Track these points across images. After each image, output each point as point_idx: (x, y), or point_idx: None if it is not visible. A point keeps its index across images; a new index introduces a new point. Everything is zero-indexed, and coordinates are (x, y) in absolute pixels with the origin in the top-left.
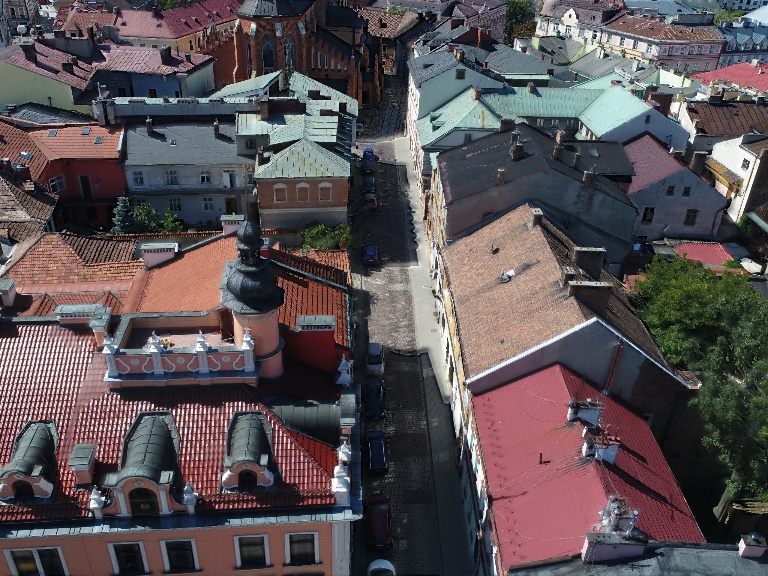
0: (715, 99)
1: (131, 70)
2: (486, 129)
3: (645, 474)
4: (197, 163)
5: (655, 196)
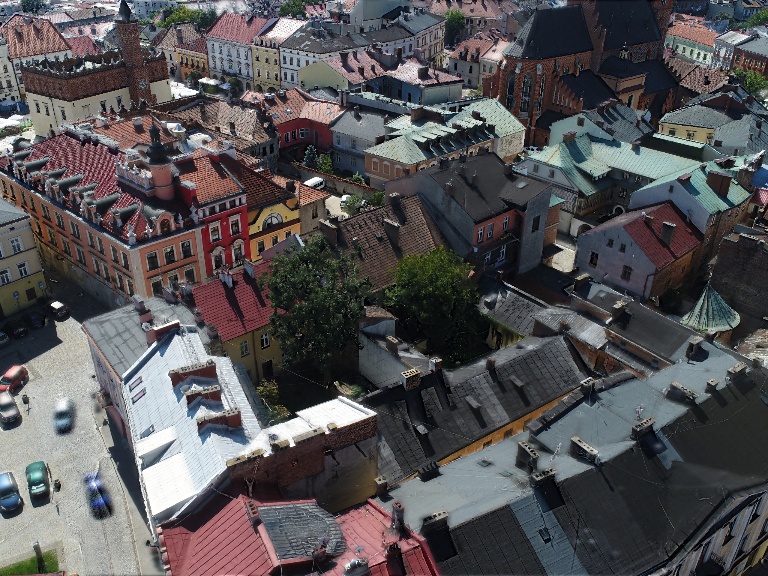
0: None
1: (400, 78)
2: (548, 164)
3: (250, 306)
4: (362, 138)
5: (598, 244)
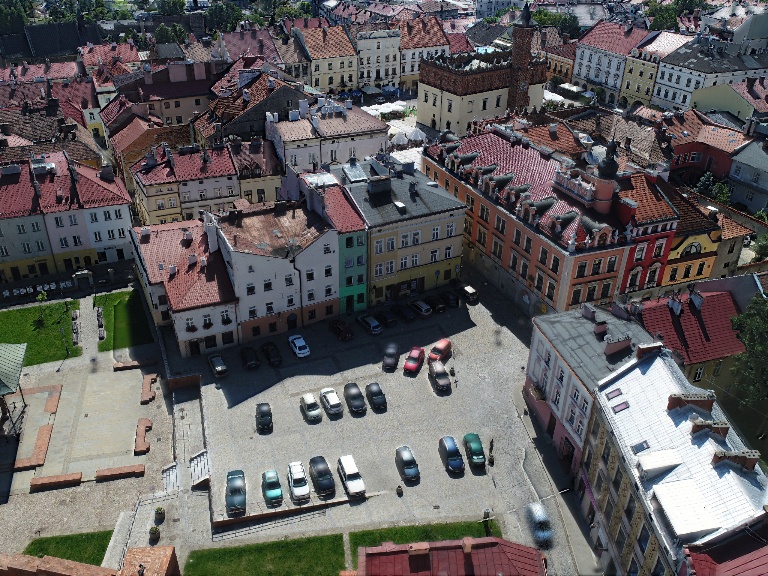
0: None
1: None
2: None
3: (695, 338)
4: None
5: None
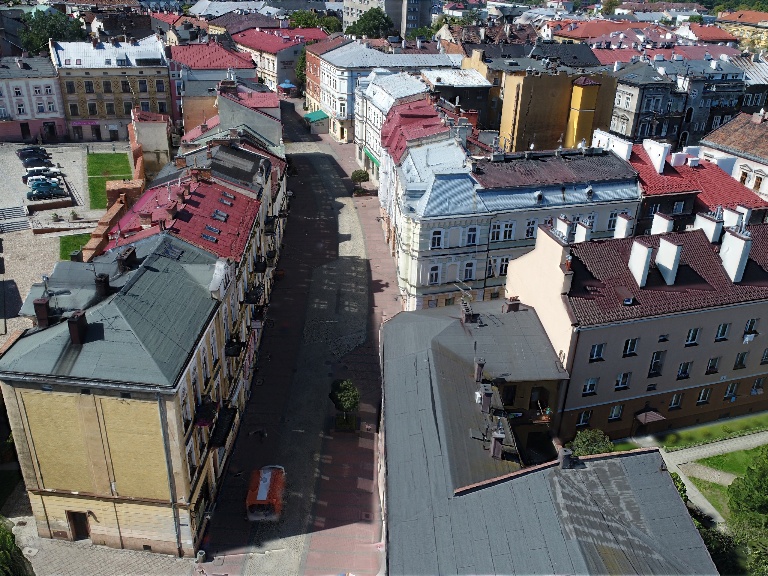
0: (94, 9)
1: None
2: None
3: None
4: None
5: None
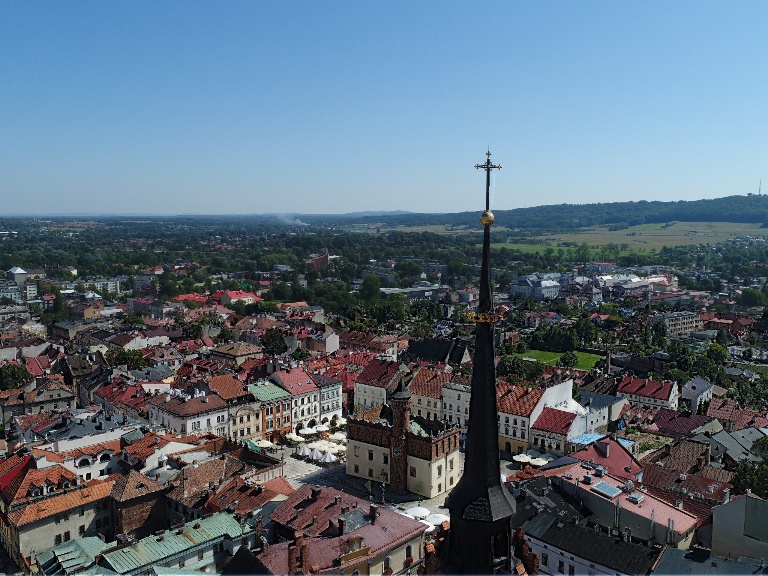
0: None
1: None
2: None
3: None
4: None
5: None
